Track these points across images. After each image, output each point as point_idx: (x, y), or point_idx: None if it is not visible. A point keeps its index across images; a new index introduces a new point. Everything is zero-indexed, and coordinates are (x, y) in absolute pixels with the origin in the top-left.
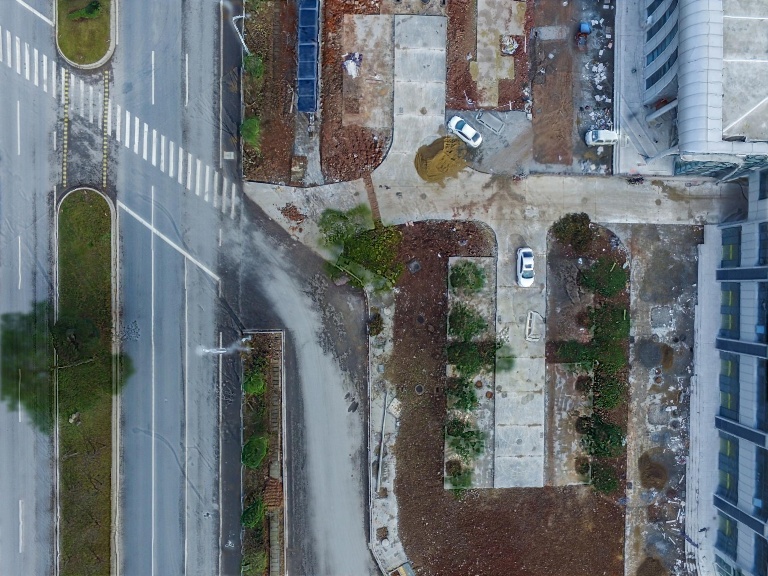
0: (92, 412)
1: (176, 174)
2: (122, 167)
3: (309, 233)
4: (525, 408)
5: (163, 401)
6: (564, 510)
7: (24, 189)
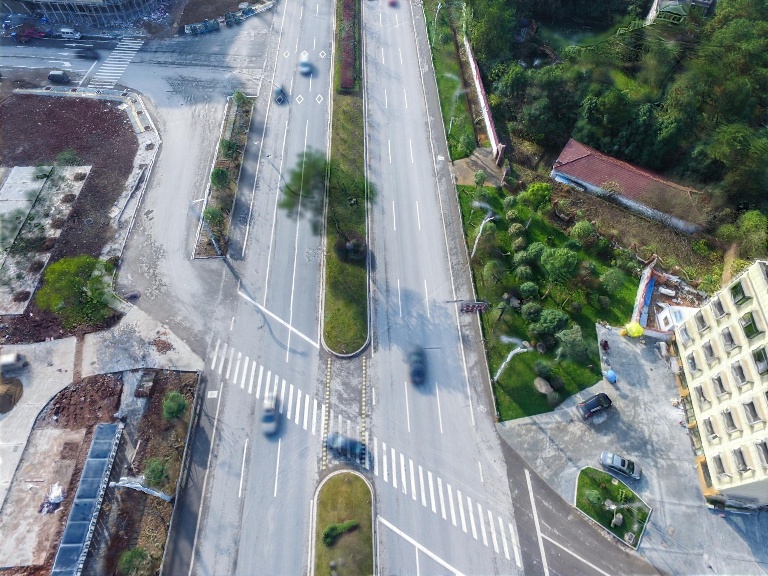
0: (340, 205)
1: (265, 374)
2: (313, 377)
3: (151, 330)
4: (5, 210)
5: (292, 214)
6: (6, 155)
7: (399, 353)
